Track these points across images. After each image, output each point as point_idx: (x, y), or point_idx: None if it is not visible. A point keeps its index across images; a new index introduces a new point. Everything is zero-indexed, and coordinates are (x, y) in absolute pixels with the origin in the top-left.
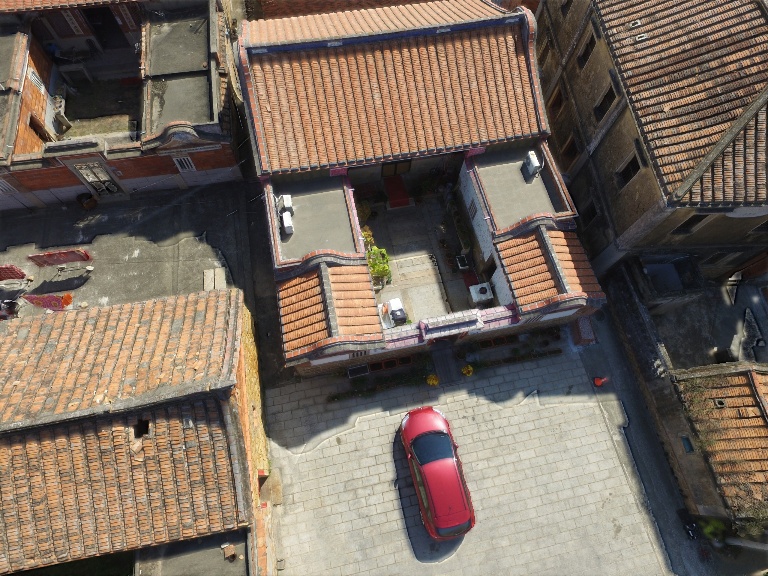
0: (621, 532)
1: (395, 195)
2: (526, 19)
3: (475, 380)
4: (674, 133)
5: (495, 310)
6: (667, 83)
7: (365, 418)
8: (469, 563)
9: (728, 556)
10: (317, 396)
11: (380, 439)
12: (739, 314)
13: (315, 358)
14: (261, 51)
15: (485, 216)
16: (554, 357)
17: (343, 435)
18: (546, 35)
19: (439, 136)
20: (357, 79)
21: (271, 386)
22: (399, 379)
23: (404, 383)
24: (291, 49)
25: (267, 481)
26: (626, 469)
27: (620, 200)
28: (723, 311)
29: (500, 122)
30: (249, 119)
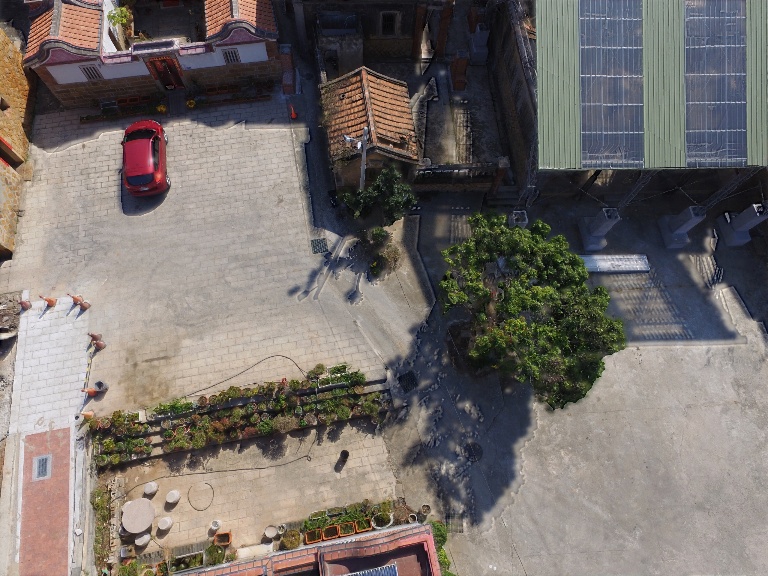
0: (282, 203)
1: None
2: None
3: (199, 113)
4: None
5: None
6: None
7: (107, 133)
8: (162, 216)
9: (359, 218)
10: (74, 120)
11: (116, 146)
12: (425, 81)
13: (48, 64)
14: None
15: None
16: (265, 101)
17: (88, 143)
18: None
19: None
20: None
21: (40, 113)
22: (138, 109)
23: (141, 111)
24: None
25: (22, 165)
26: (298, 167)
27: None
28: (412, 78)
29: None
30: None
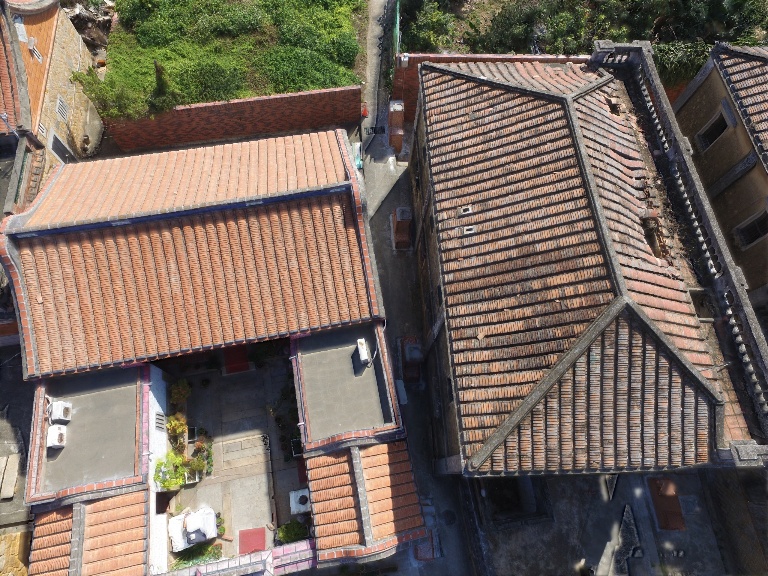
0: None
1: (233, 358)
2: (352, 190)
3: None
4: (484, 372)
5: (295, 547)
6: (487, 299)
7: None
8: None
9: None
10: None
11: None
12: (616, 513)
13: None
14: (29, 235)
15: (299, 420)
16: (389, 574)
17: None
18: (415, 171)
19: (249, 324)
20: (151, 260)
21: None
22: None
23: None
24: (67, 231)
25: None
26: None
27: (449, 414)
28: (598, 509)
29: (324, 306)
30: (17, 311)
